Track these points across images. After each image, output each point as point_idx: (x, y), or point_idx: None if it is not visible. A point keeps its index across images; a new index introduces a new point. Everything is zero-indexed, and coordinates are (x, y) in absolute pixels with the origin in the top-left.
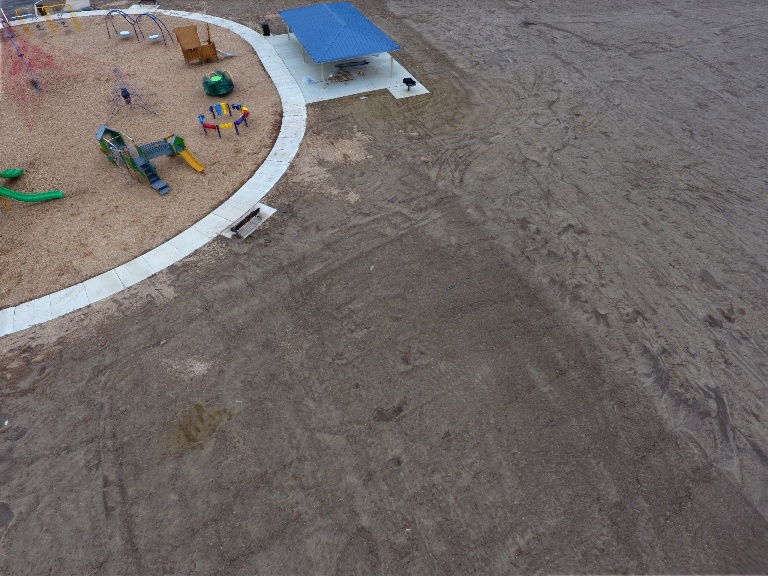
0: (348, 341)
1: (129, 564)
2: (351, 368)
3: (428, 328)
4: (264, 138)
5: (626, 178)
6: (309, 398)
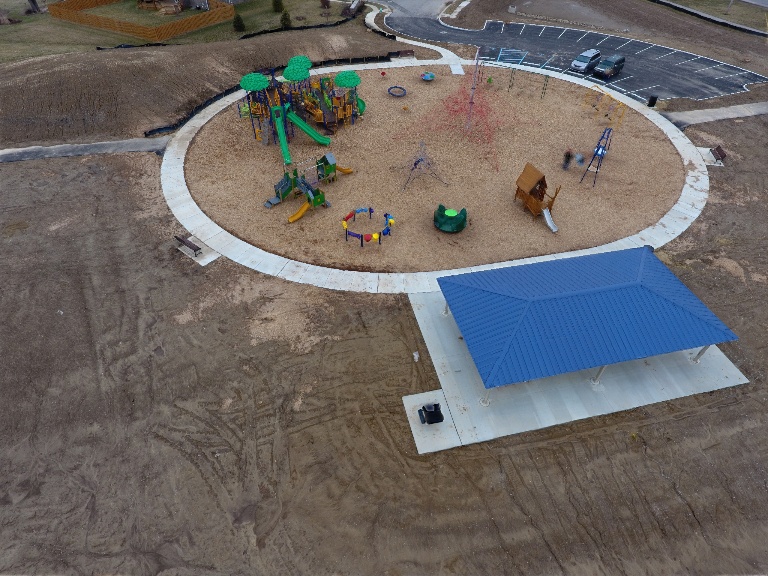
0: None
1: None
2: None
3: None
4: (335, 259)
5: None
6: None
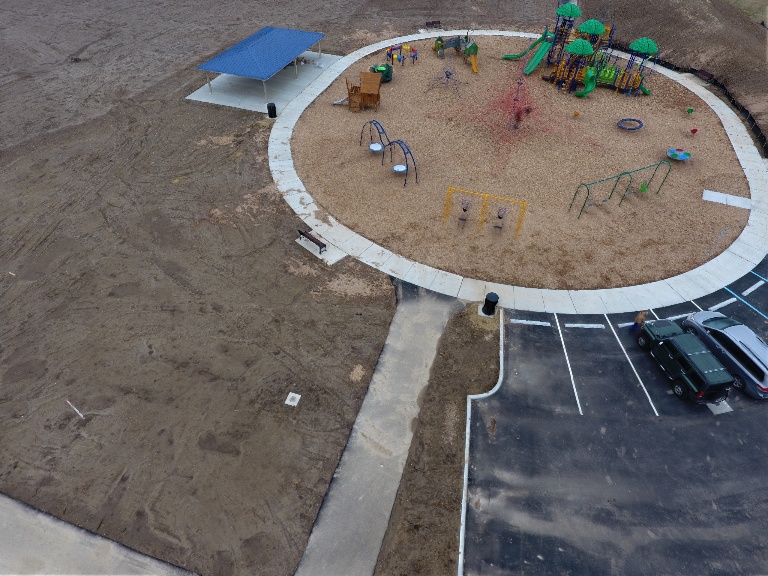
0: None
1: (500, 0)
2: None
3: None
4: None
5: (284, 4)
6: None
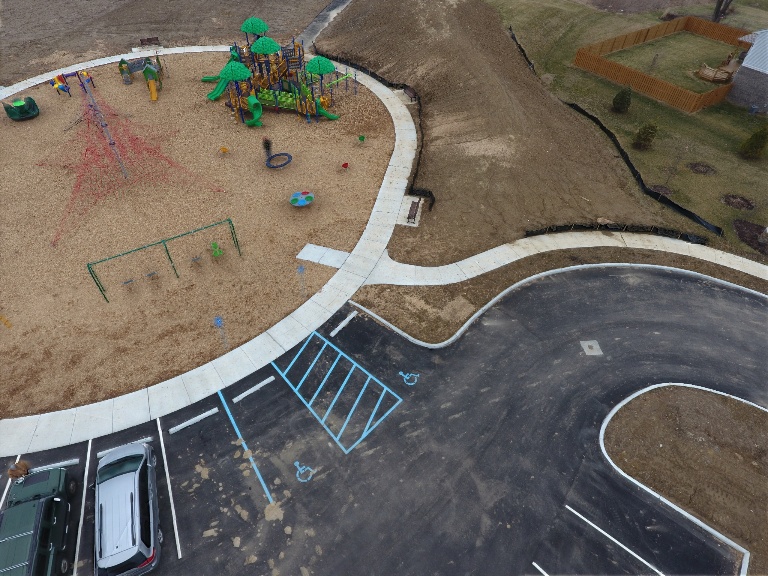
0: (175, 7)
1: None
2: None
3: (154, 4)
4: None
5: (1, 21)
6: (198, 4)
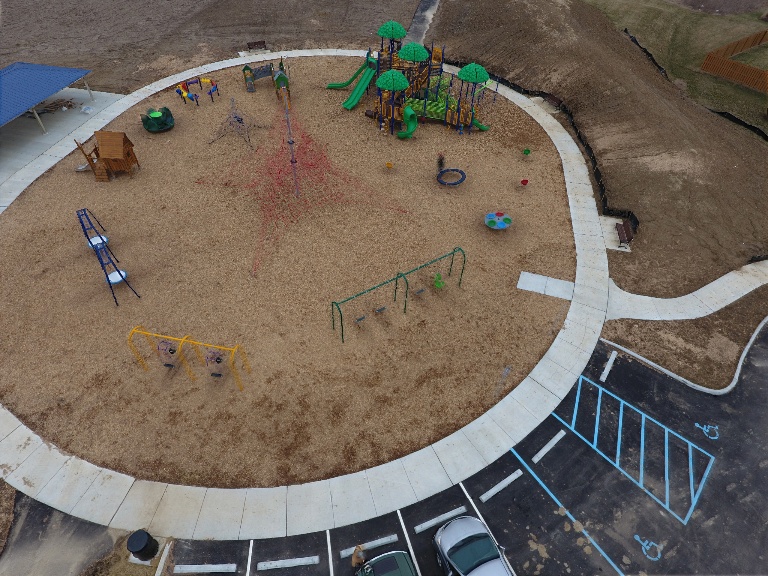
0: (269, 8)
1: None
2: (276, 4)
3: None
4: None
5: None
6: (292, 5)
